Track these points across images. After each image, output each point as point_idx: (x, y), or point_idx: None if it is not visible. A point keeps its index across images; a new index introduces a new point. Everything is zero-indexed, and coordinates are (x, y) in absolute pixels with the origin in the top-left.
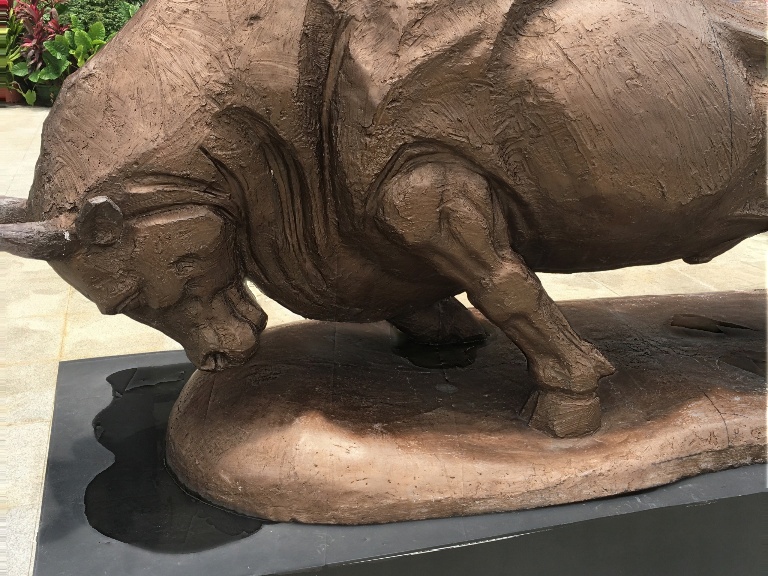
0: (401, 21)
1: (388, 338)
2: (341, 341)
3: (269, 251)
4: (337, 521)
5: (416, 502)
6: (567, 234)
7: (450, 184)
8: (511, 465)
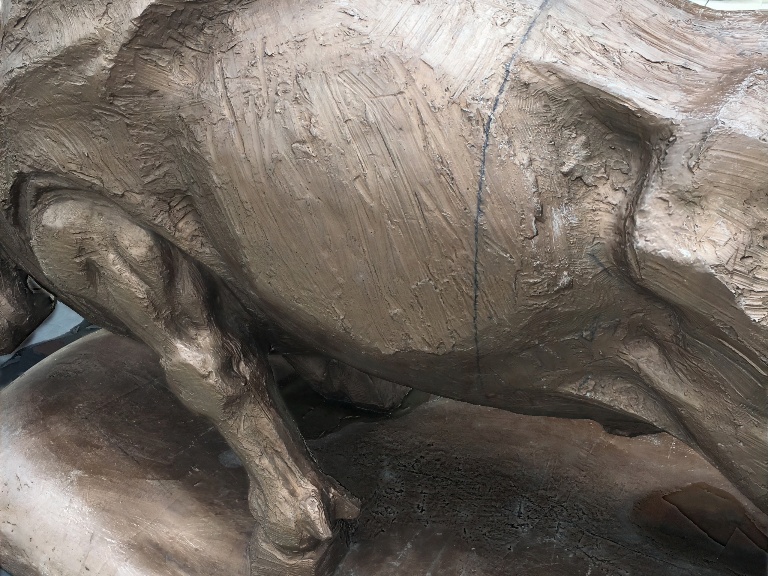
0: (4, 17)
1: (292, 368)
2: None
3: None
4: None
5: (44, 575)
6: None
7: (97, 232)
8: None
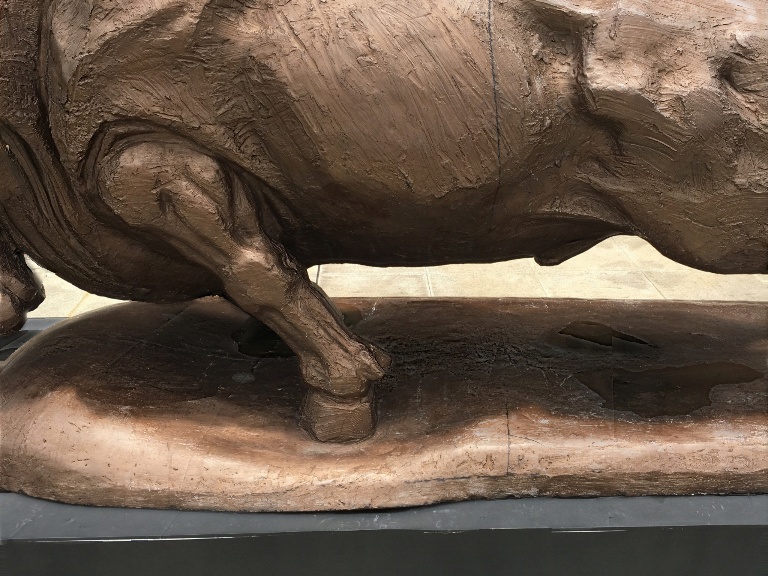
0: None
1: (241, 321)
2: (177, 320)
3: (30, 225)
4: (57, 498)
5: (132, 489)
6: (333, 224)
7: (170, 165)
8: (245, 464)
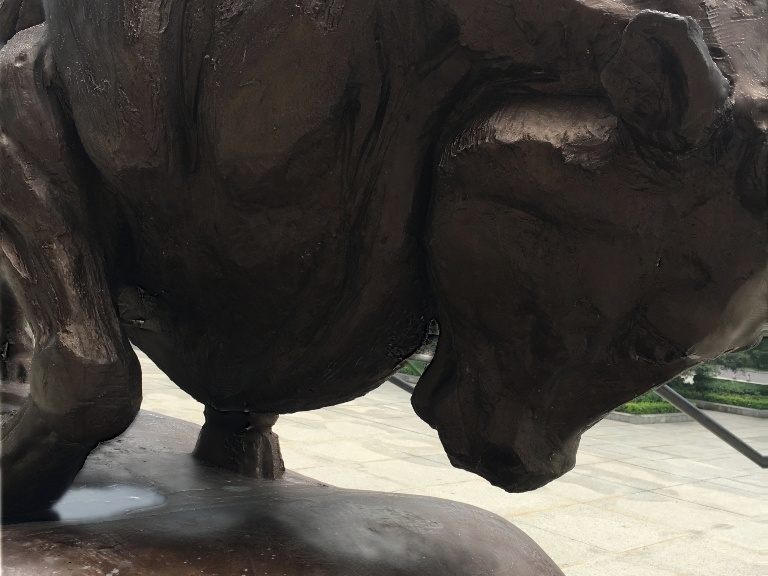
0: None
1: None
2: None
3: None
4: None
5: None
6: None
7: None
8: None
